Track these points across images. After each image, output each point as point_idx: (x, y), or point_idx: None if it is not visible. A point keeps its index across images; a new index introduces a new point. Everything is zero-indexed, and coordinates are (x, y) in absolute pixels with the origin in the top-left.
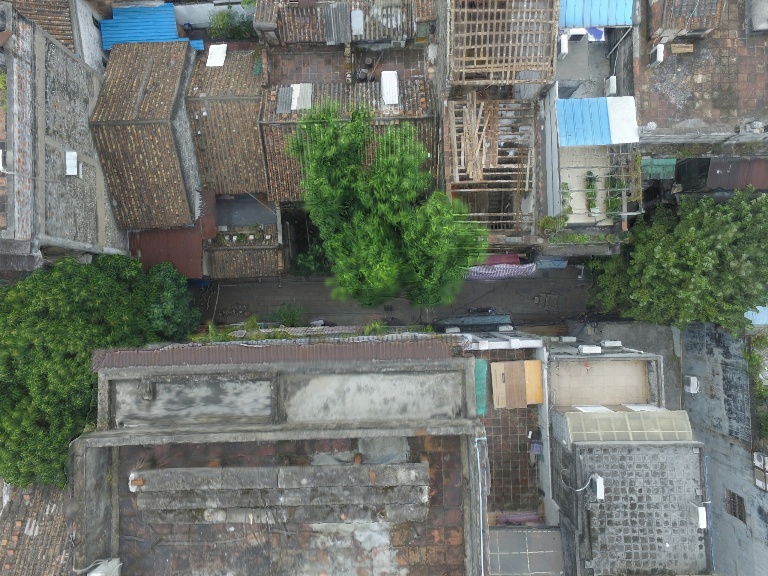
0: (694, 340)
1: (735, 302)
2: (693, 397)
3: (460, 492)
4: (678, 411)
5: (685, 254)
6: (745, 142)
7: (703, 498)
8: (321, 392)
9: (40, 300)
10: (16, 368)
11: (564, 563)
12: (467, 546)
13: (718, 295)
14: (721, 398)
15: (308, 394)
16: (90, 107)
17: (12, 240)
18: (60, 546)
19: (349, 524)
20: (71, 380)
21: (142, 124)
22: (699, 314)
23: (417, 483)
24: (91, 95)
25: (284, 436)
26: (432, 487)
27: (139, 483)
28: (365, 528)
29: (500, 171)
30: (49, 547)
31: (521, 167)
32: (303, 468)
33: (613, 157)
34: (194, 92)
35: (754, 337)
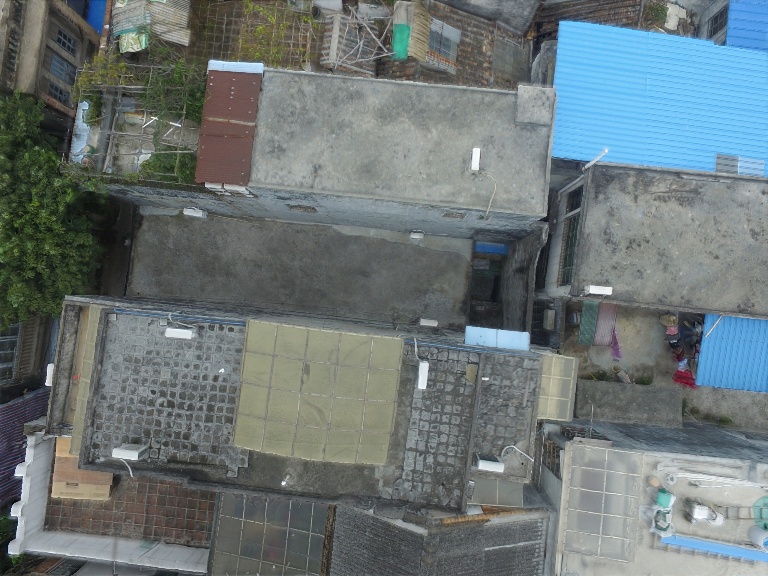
0: None
1: None
2: (213, 211)
3: None
4: (89, 315)
5: None
6: None
7: None
8: None
9: None
10: None
11: None
12: None
13: None
14: None
15: None
16: None
17: None
18: None
19: None
20: None
21: None
22: None
23: None
24: None
25: None
26: None
27: None
28: None
29: None
30: None
31: None
32: None
33: None
34: None
35: None
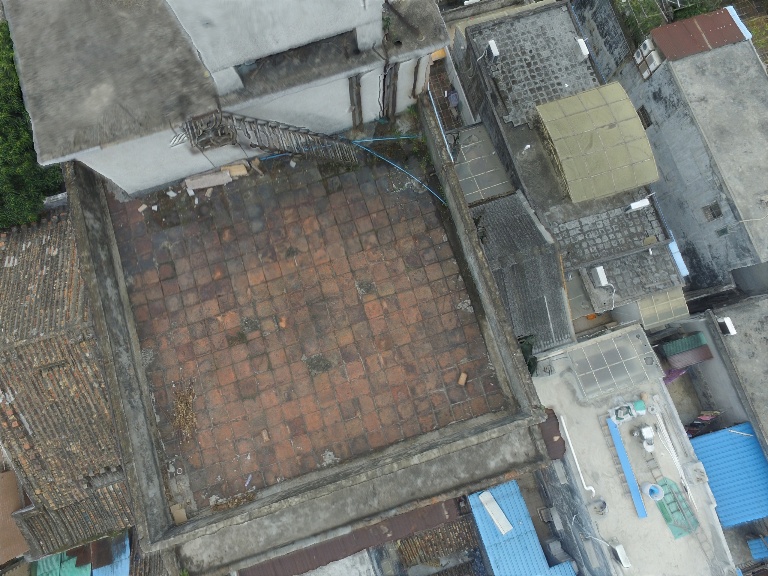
0: None
1: None
2: None
3: None
4: None
5: None
6: None
7: None
8: None
9: None
10: None
11: (493, 145)
12: None
13: None
14: (602, 45)
15: None
16: None
17: None
18: (40, 264)
19: None
20: None
21: None
22: None
23: None
24: None
25: None
26: None
27: None
28: None
29: None
30: (30, 268)
31: None
32: None
33: None
34: None
35: None
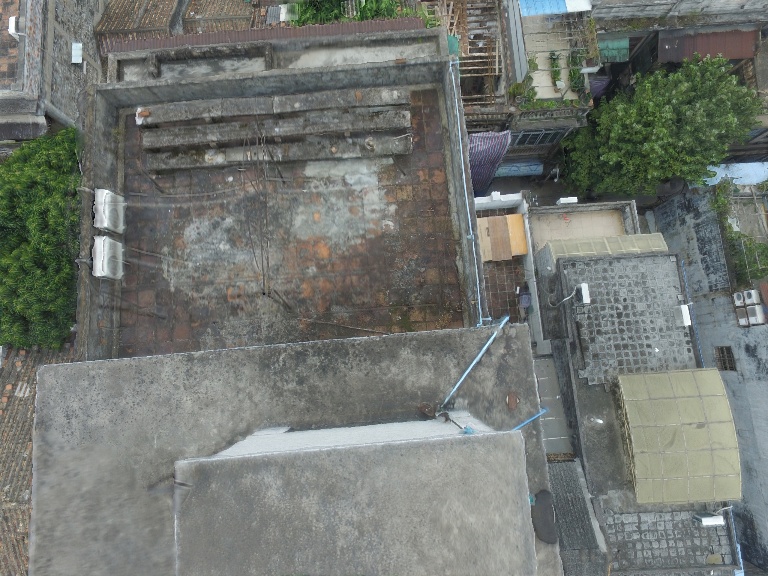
0: (667, 220)
1: (696, 155)
2: None
3: (441, 139)
4: None
5: (645, 113)
6: (686, 15)
7: (685, 302)
8: (311, 64)
9: (43, 154)
10: (18, 207)
11: (559, 387)
12: (450, 185)
13: (679, 144)
14: (698, 260)
15: (299, 67)
16: (95, 19)
17: (19, 101)
18: None
19: (340, 169)
20: (71, 215)
21: (143, 32)
22: (666, 172)
23: (399, 101)
24: (96, 10)
25: (278, 72)
26: (415, 135)
27: (145, 113)
28: (355, 172)
29: (472, 59)
30: None
31: (491, 55)
32: (296, 94)
33: (572, 41)
34: (191, 16)
35: (718, 183)
